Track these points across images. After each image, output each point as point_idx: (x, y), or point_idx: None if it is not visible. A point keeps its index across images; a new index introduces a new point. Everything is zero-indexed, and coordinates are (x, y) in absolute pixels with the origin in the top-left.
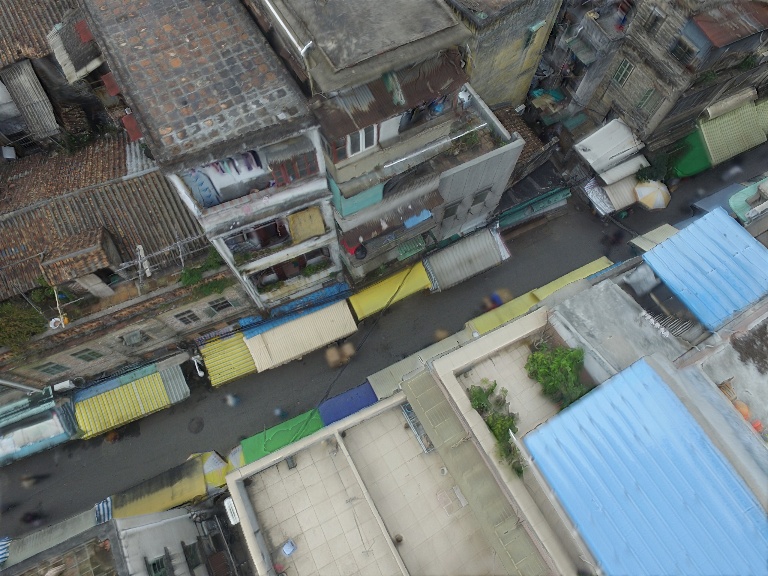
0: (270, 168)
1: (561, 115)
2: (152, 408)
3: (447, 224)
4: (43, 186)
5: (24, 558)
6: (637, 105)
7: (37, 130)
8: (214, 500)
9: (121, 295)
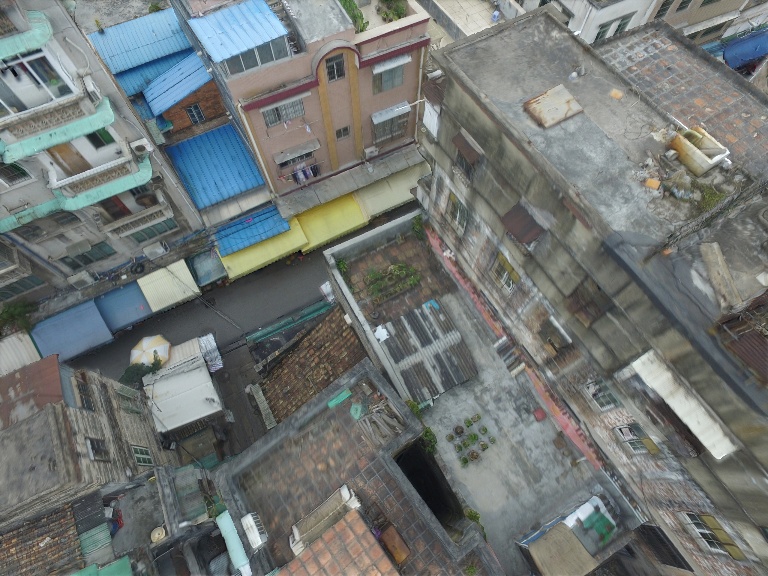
0: None
1: None
2: None
3: None
4: None
5: None
6: None
7: None
8: None
9: None
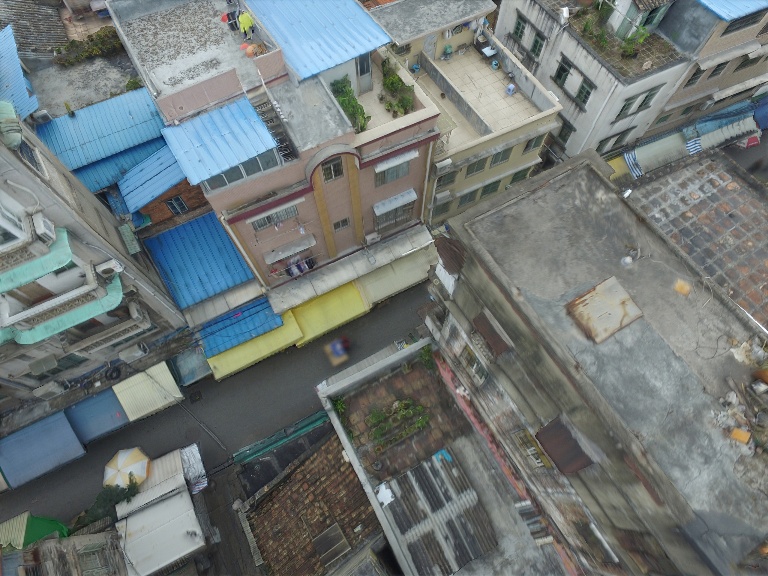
0: None
1: None
2: None
3: None
4: None
5: (675, 145)
6: None
7: None
8: None
9: None
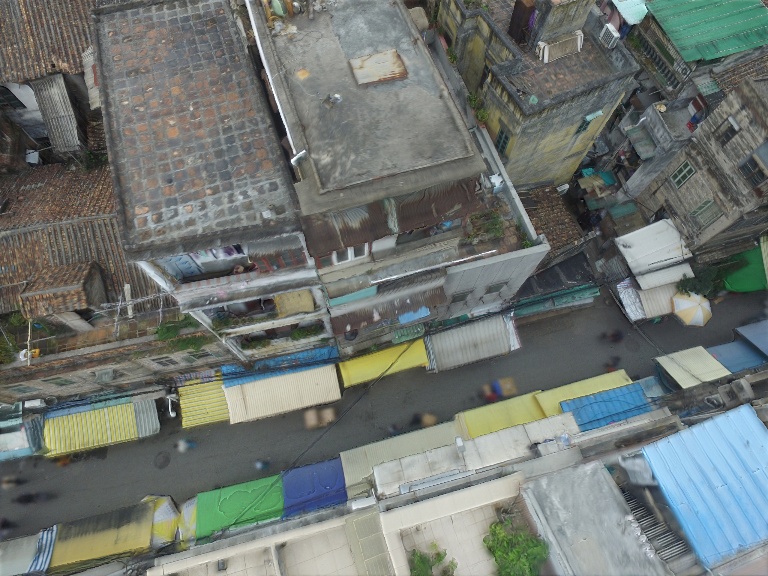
0: (250, 260)
1: (607, 201)
2: (119, 438)
3: (455, 307)
4: (48, 205)
5: None
6: (691, 212)
7: (58, 144)
8: (158, 551)
9: (100, 332)
